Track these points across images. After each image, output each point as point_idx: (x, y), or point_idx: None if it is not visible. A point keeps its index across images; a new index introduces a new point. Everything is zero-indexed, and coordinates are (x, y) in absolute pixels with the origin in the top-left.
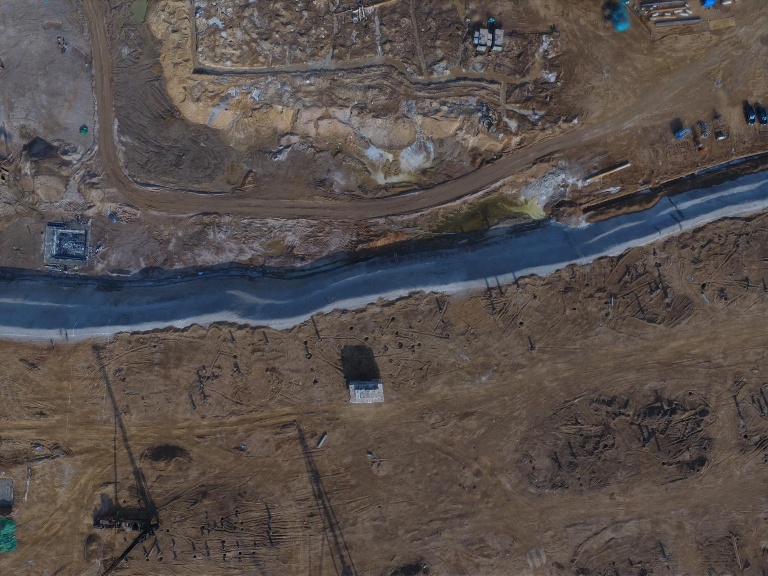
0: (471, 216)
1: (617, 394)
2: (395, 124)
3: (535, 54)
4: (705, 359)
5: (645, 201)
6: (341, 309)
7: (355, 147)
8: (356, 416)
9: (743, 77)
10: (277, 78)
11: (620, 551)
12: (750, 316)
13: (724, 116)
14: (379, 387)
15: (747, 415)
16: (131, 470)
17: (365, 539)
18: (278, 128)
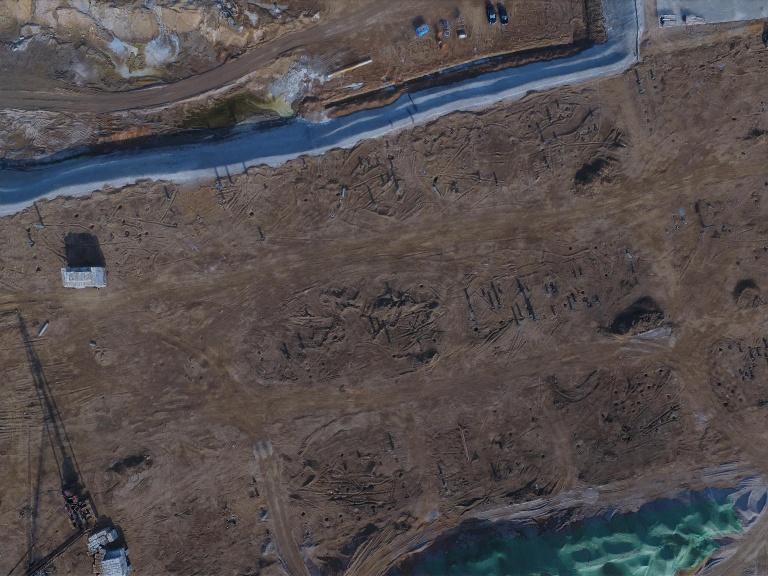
0: (218, 112)
1: (348, 286)
2: (133, 14)
3: None
4: (437, 252)
5: (385, 97)
6: (65, 196)
7: (98, 39)
8: (80, 305)
9: None
10: None
11: (348, 443)
12: (481, 210)
13: (467, 15)
14: (92, 270)
15: (477, 308)
16: None
17: (87, 430)
18: (18, 18)
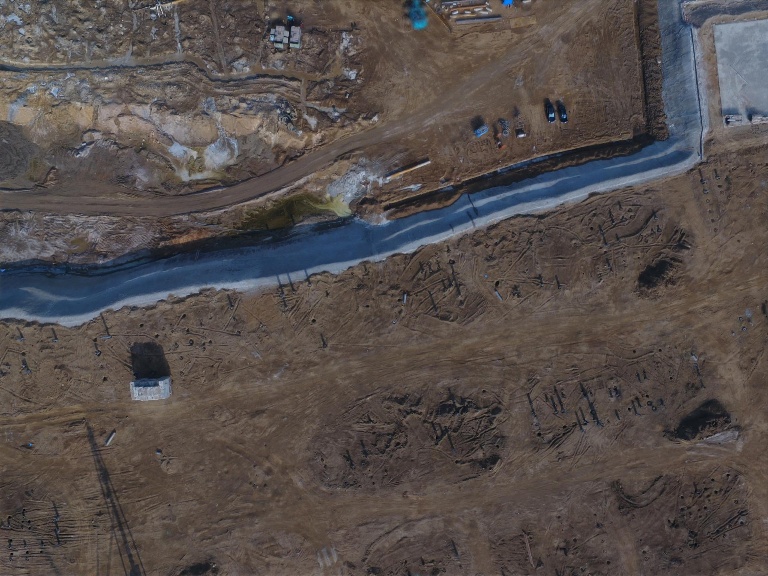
0: (276, 213)
1: (410, 392)
2: (194, 121)
3: (336, 51)
4: (499, 357)
5: (444, 198)
6: (131, 306)
7: (158, 144)
8: (146, 414)
9: (544, 75)
10: (76, 74)
11: (412, 550)
12: (544, 314)
13: (525, 114)
14: (160, 384)
15: (540, 413)
16: None
17: (154, 538)
18: (80, 125)
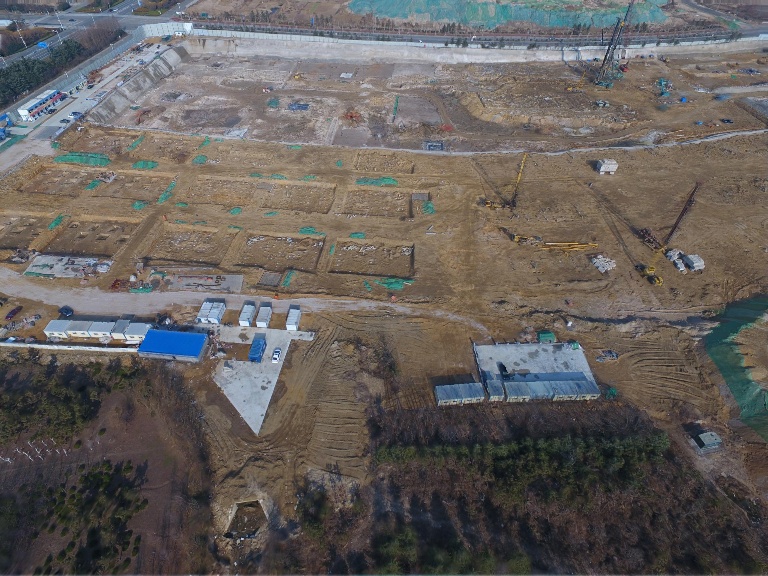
0: (620, 144)
1: None
2: (575, 119)
3: None
4: None
5: None
6: None
7: (558, 127)
8: None
9: None
10: (519, 110)
11: None
12: None
13: None
14: None
15: None
16: (492, 191)
17: (635, 217)
18: (523, 122)
